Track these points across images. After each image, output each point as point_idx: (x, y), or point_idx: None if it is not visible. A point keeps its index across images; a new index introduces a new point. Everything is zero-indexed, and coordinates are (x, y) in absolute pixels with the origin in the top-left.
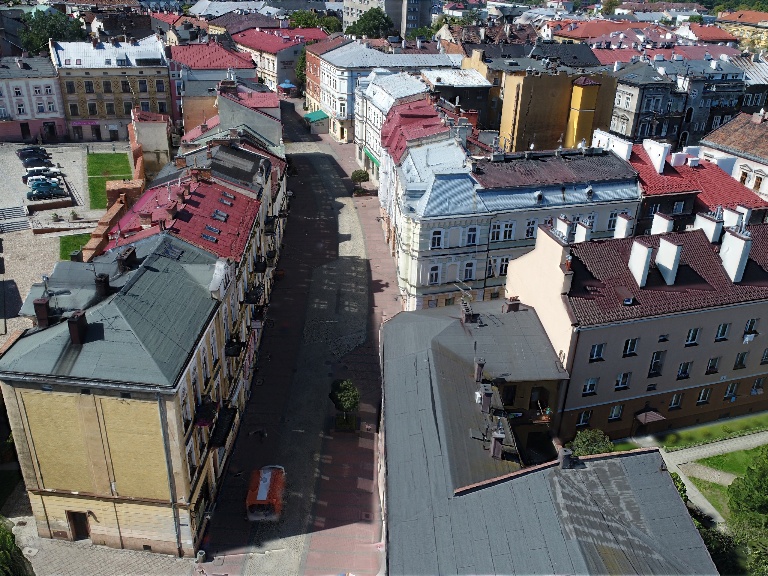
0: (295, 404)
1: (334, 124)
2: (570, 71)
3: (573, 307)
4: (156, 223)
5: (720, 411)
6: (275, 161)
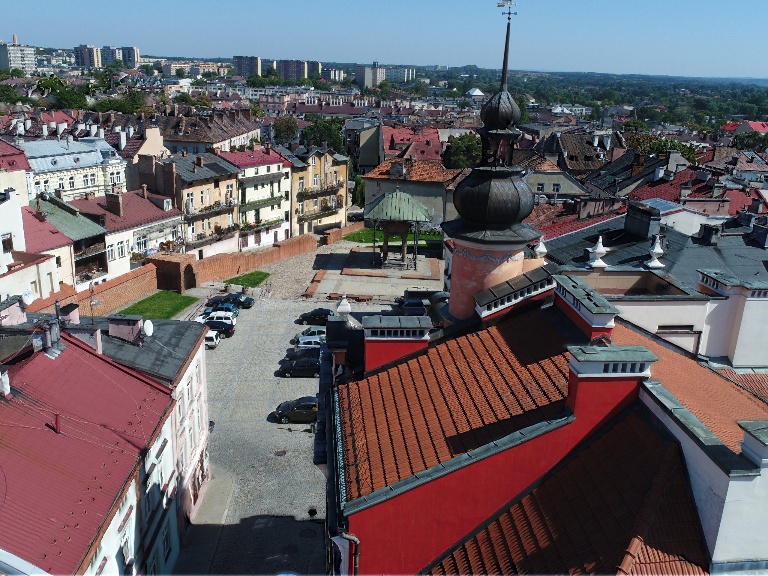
0: None
1: None
2: None
3: None
4: None
5: None
6: None
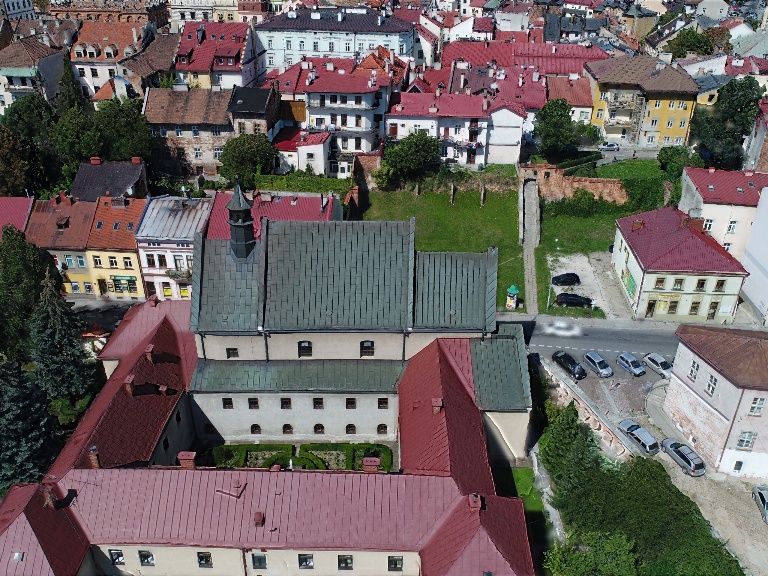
0: None
1: None
2: None
3: None
4: (596, 1)
5: None
6: None
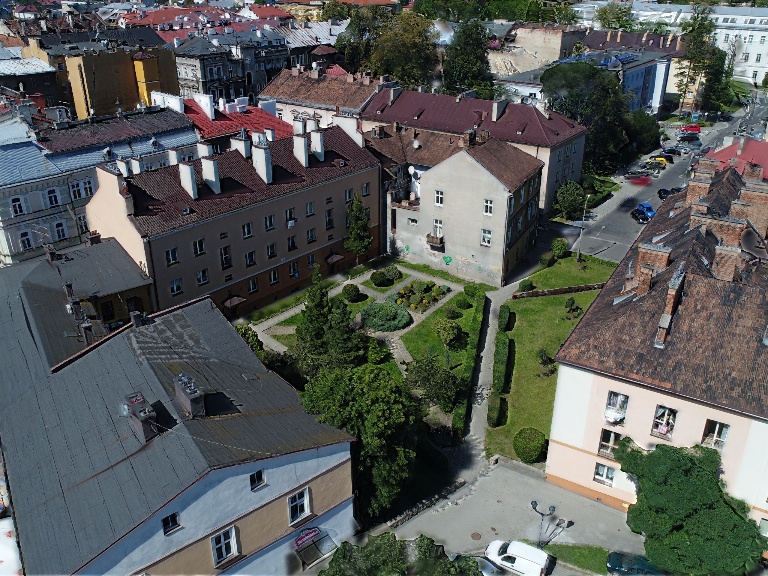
0: None
1: None
2: (129, 49)
3: (140, 224)
4: None
5: (291, 287)
6: None
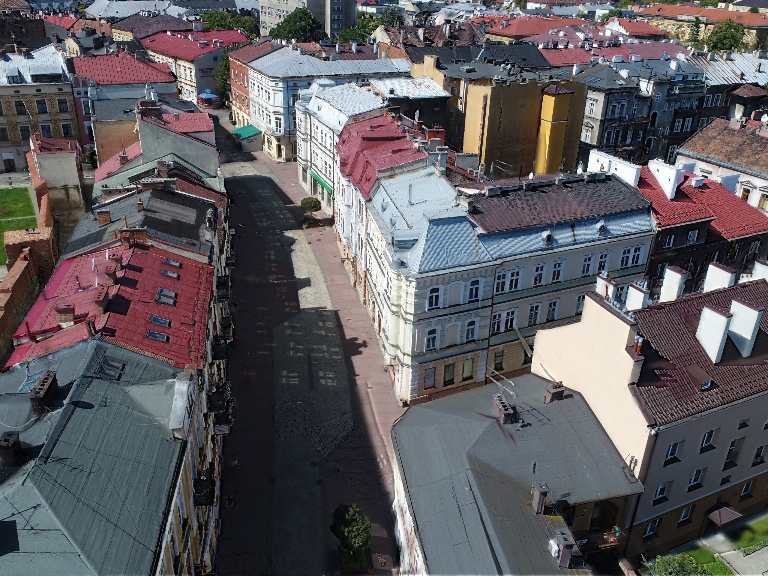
0: (281, 534)
1: (269, 141)
2: None
3: (644, 401)
4: (80, 319)
5: None
6: (214, 197)
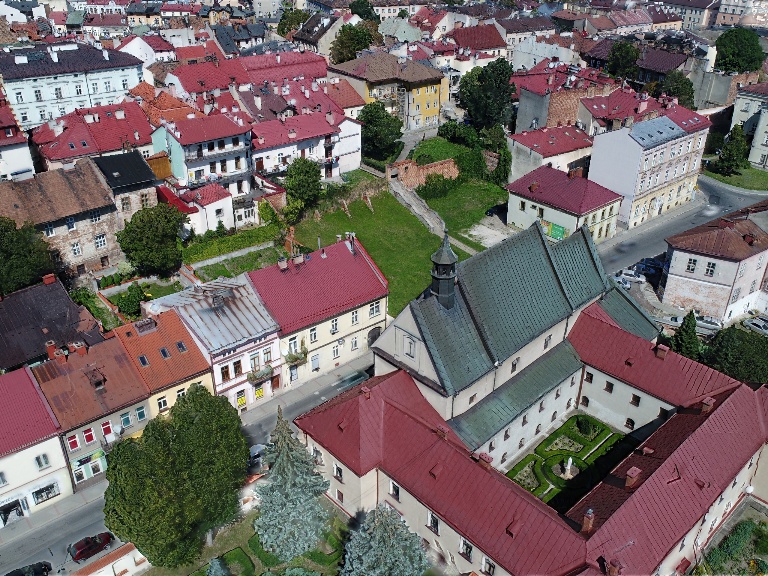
0: None
1: None
2: None
3: None
4: None
5: None
6: None
